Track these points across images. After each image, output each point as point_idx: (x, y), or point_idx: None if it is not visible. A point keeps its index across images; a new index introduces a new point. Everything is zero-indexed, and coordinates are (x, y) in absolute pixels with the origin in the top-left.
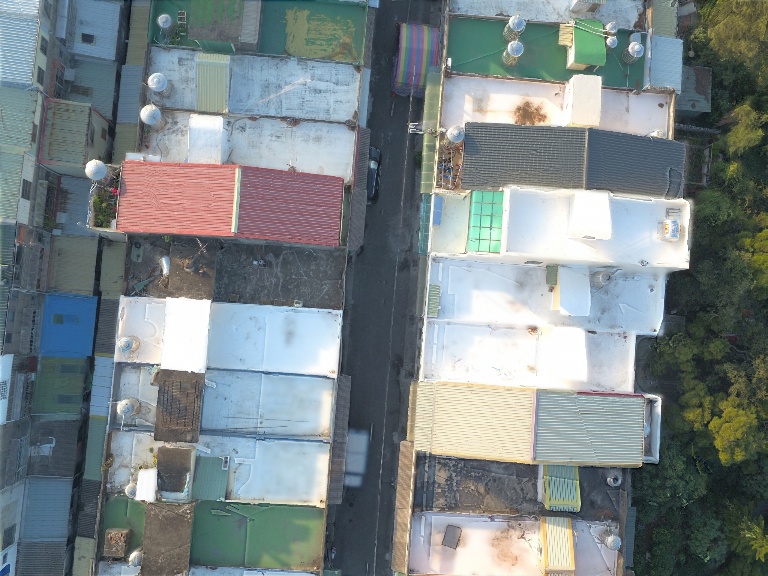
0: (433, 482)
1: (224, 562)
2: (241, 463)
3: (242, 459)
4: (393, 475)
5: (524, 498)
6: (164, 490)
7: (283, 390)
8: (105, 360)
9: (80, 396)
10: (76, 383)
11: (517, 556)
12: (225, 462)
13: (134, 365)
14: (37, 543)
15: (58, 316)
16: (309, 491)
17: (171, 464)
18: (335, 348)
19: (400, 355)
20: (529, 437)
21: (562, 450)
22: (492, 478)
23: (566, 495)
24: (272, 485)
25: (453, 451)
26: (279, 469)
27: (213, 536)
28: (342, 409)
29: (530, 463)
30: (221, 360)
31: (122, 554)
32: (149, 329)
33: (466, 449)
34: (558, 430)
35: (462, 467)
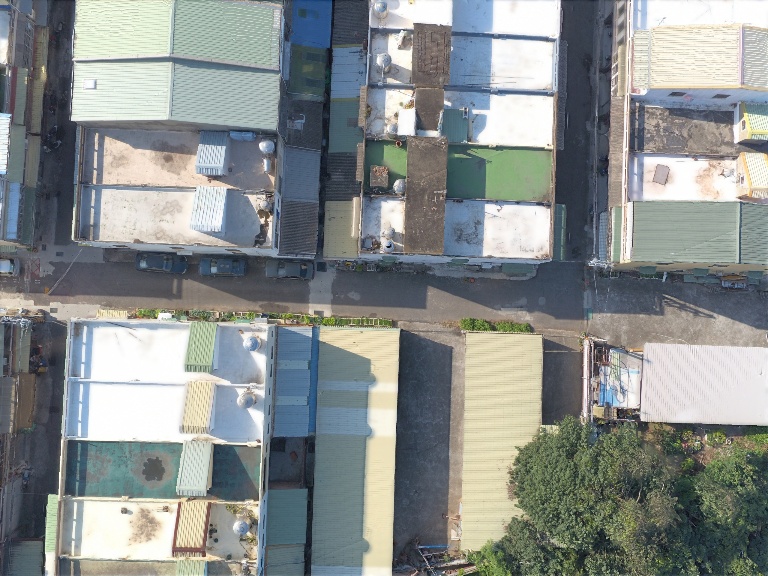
0: (643, 128)
1: (468, 196)
2: (478, 114)
3: (478, 111)
4: (588, 158)
5: (722, 141)
6: (420, 129)
7: (510, 52)
8: (342, 50)
9: (323, 81)
10: (319, 70)
11: (718, 191)
12: (465, 112)
13: (383, 33)
14: (296, 203)
15: (302, 10)
16: (537, 137)
17: (427, 102)
18: (554, 15)
19: (589, 54)
20: (737, 65)
21: (765, 78)
22: (694, 124)
23: (765, 126)
24: (505, 132)
25: (670, 83)
26: (510, 119)
27: (457, 176)
28: (561, 68)
29: (739, 87)
30: (456, 27)
31: (386, 184)
32: (393, 3)
33: (681, 80)
34: (761, 61)
35: (668, 115)
